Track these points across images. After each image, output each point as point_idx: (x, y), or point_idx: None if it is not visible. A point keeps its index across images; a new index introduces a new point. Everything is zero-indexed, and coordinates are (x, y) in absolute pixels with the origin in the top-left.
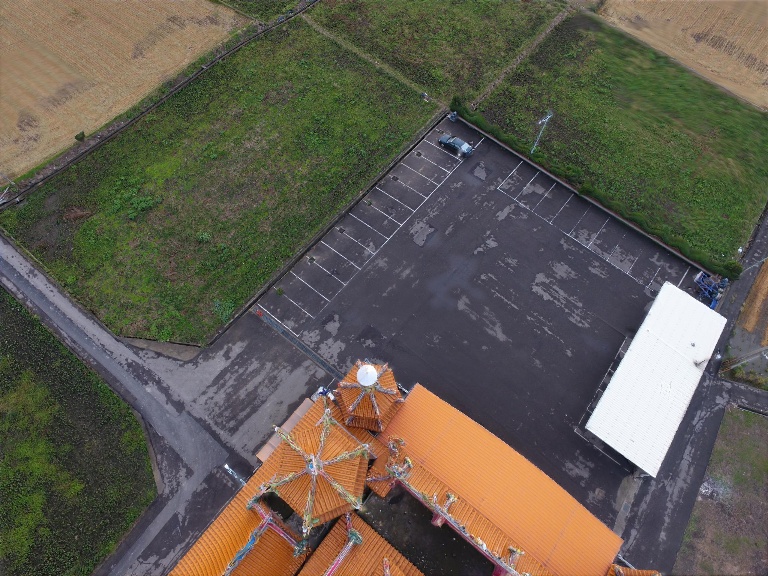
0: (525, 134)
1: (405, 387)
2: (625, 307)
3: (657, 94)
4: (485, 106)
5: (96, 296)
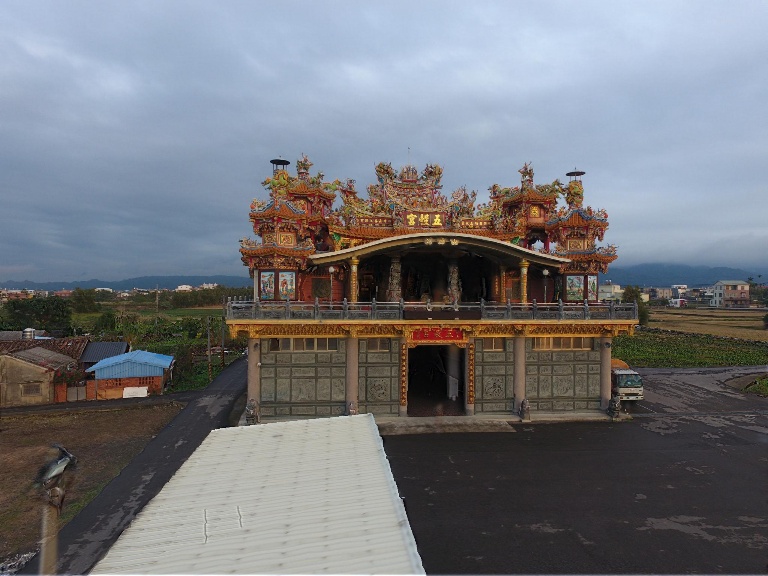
0: None
1: (609, 431)
2: None
3: None
4: None
5: None
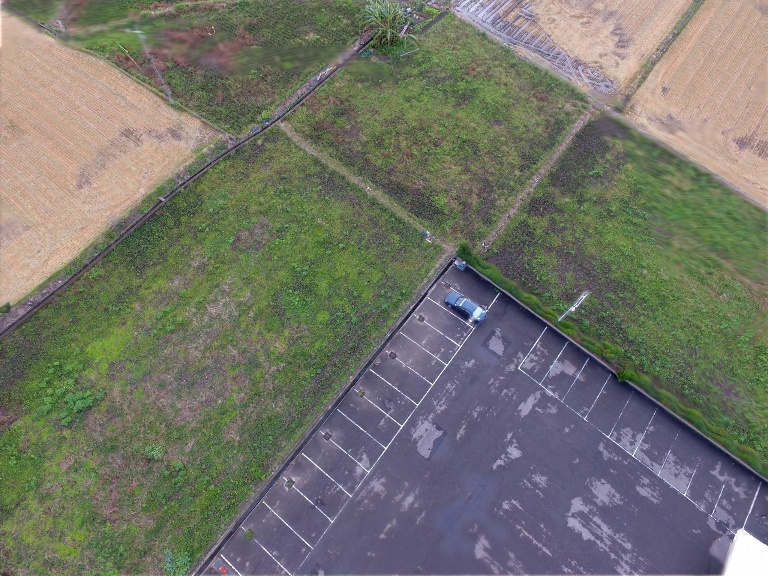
0: (548, 285)
1: None
2: (685, 549)
3: (701, 226)
4: (499, 245)
5: (13, 548)
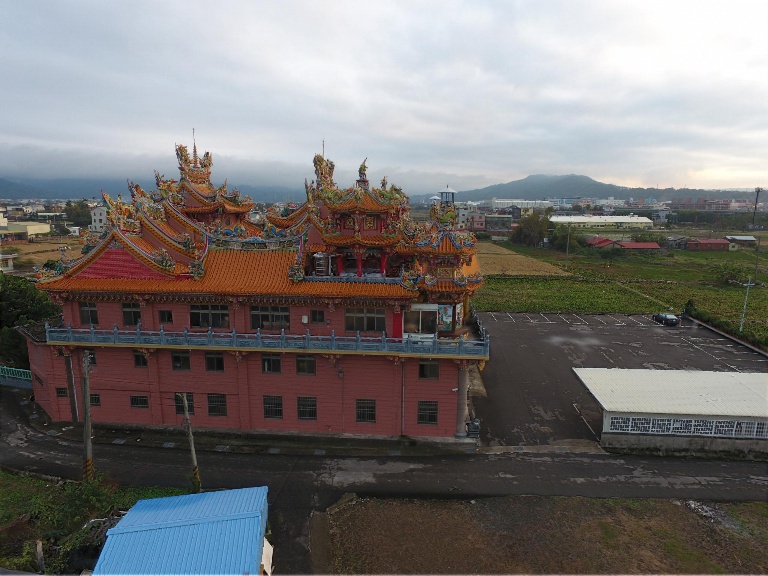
0: None
1: None
2: None
3: None
4: None
5: None
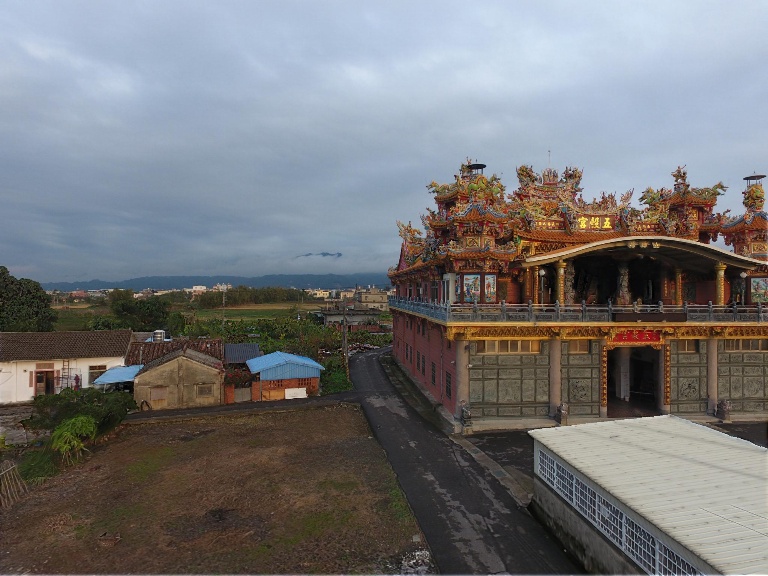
0: None
1: None
2: None
3: None
4: None
5: None
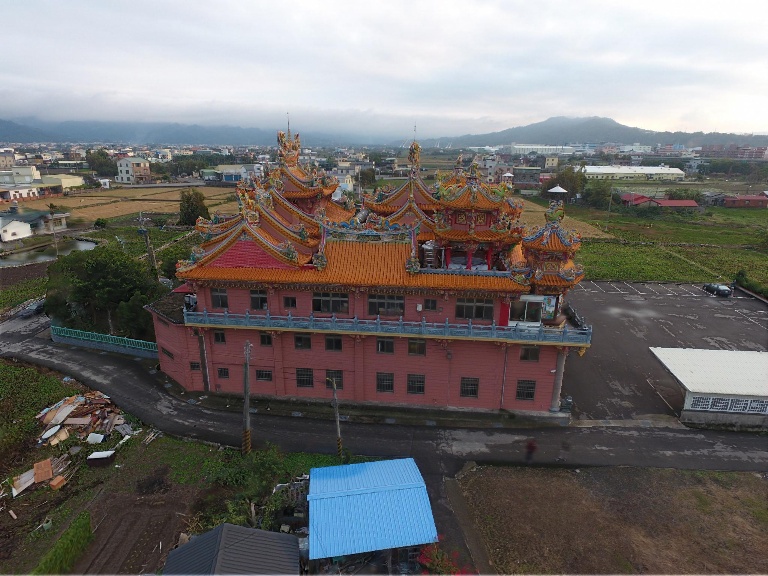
0: None
1: None
2: None
3: None
4: None
5: None
